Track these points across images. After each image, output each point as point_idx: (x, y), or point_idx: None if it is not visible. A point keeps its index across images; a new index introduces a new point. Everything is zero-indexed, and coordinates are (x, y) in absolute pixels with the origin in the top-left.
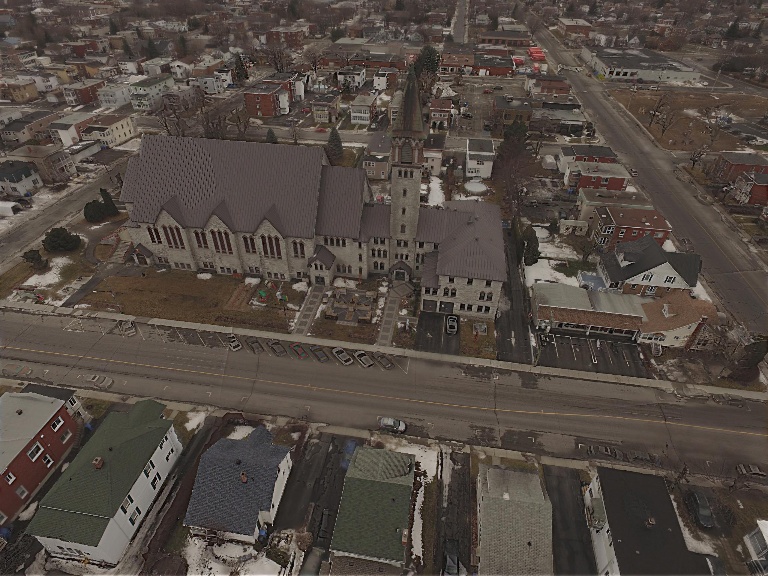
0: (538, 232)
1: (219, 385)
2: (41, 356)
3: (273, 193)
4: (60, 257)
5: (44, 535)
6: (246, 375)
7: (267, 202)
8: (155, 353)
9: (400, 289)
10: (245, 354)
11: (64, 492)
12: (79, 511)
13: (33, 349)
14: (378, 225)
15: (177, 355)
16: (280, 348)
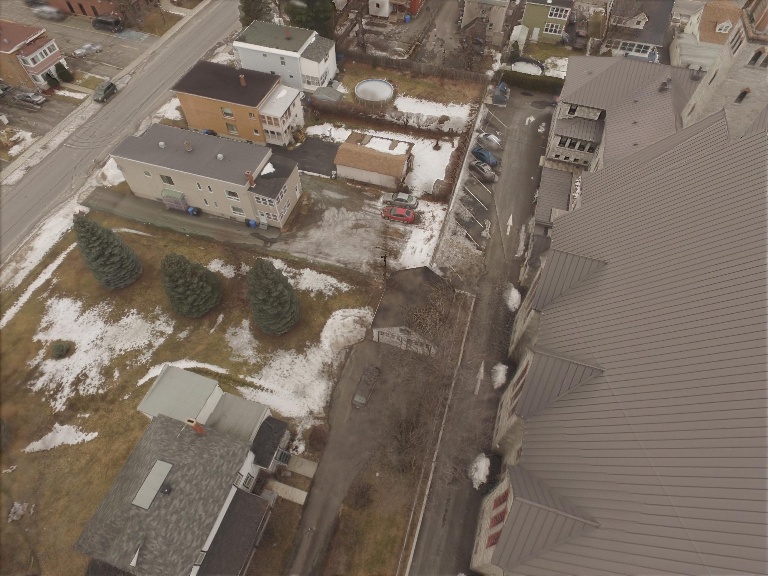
0: (526, 70)
1: None
2: None
3: None
4: None
5: None
6: None
7: None
8: None
9: None
10: None
11: None
12: None
13: None
14: None
15: None
16: None
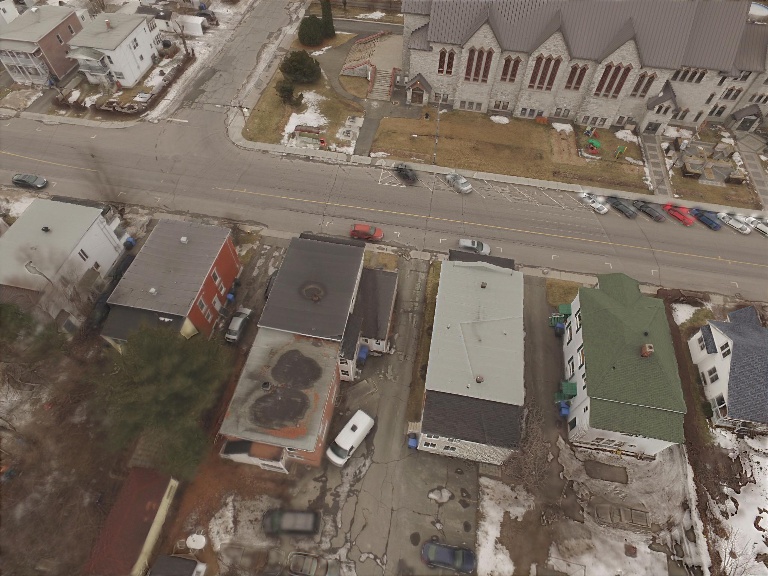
0: None
1: (614, 255)
2: (378, 215)
3: (632, 1)
4: (306, 91)
5: (615, 430)
6: (638, 244)
7: (622, 15)
8: (511, 215)
9: (748, 141)
10: (618, 218)
11: (613, 382)
12: (642, 404)
13: (362, 206)
14: (747, 53)
15: (539, 218)
16: (654, 212)
